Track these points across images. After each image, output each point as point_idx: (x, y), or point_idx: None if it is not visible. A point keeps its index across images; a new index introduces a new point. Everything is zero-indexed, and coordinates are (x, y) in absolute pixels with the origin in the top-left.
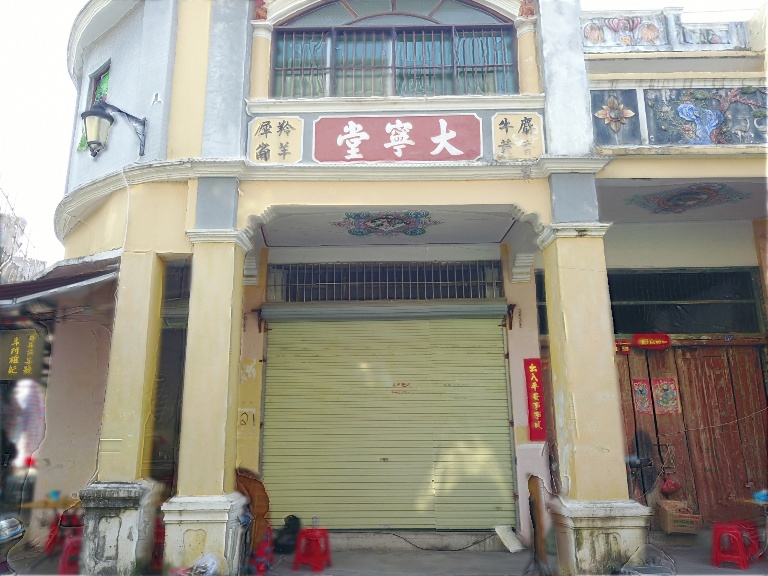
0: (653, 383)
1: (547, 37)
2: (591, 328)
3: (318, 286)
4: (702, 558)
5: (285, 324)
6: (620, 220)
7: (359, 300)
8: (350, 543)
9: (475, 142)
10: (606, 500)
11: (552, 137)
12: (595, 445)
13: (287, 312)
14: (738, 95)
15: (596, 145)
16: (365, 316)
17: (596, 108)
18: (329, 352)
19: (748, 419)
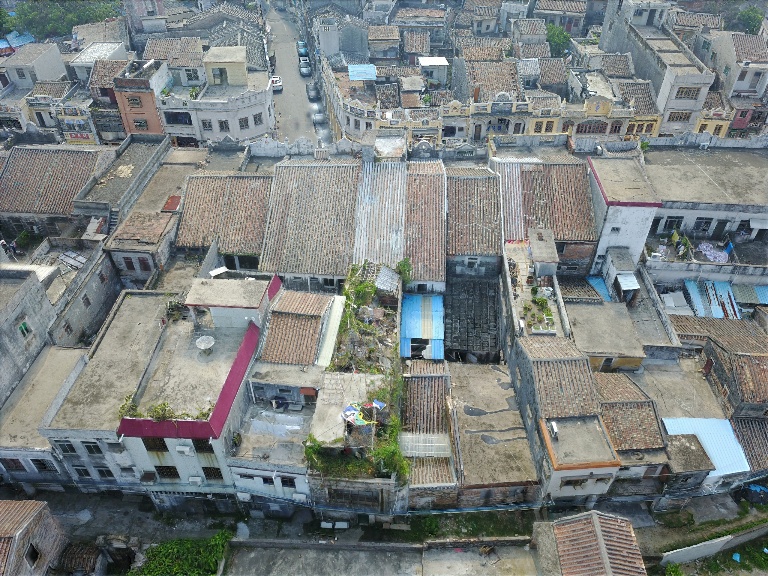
0: None
1: (22, 125)
2: None
3: None
4: None
5: None
6: None
7: None
8: None
9: None
10: None
11: None
12: None
13: None
14: None
15: None
16: None
17: None
18: None
19: None
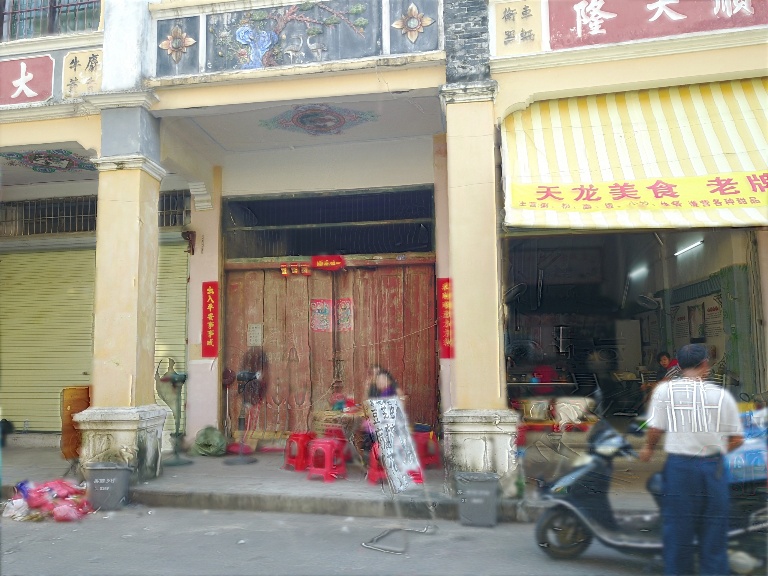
0: (337, 302)
1: None
2: (118, 255)
3: (39, 220)
4: (280, 461)
5: (8, 256)
6: (295, 144)
7: (68, 232)
8: (44, 442)
9: (48, 83)
10: (109, 407)
11: (103, 73)
12: (108, 360)
13: (1, 245)
14: (296, 12)
15: (156, 77)
16: (66, 247)
17: (161, 39)
18: (44, 280)
19: (414, 336)
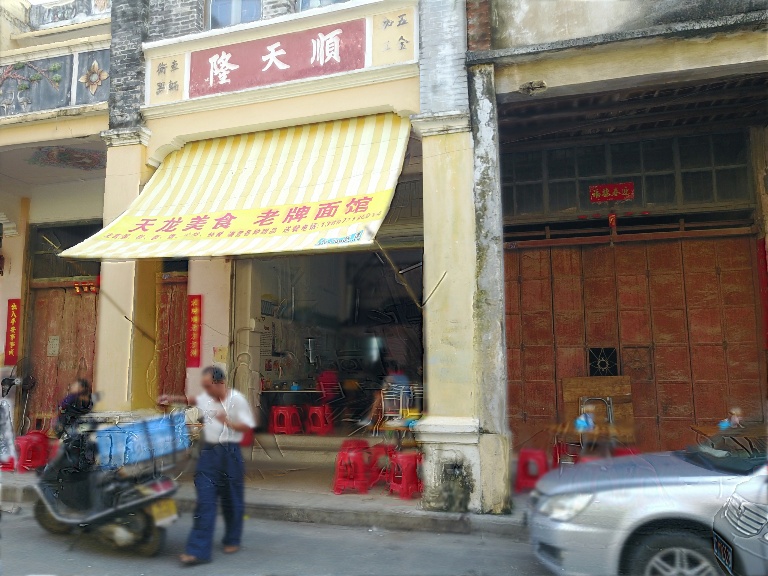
0: None
1: None
2: None
3: None
4: None
5: None
6: (80, 177)
7: None
8: None
9: None
10: None
11: None
12: None
13: None
14: (11, 71)
15: None
16: None
17: None
18: None
19: (176, 347)
